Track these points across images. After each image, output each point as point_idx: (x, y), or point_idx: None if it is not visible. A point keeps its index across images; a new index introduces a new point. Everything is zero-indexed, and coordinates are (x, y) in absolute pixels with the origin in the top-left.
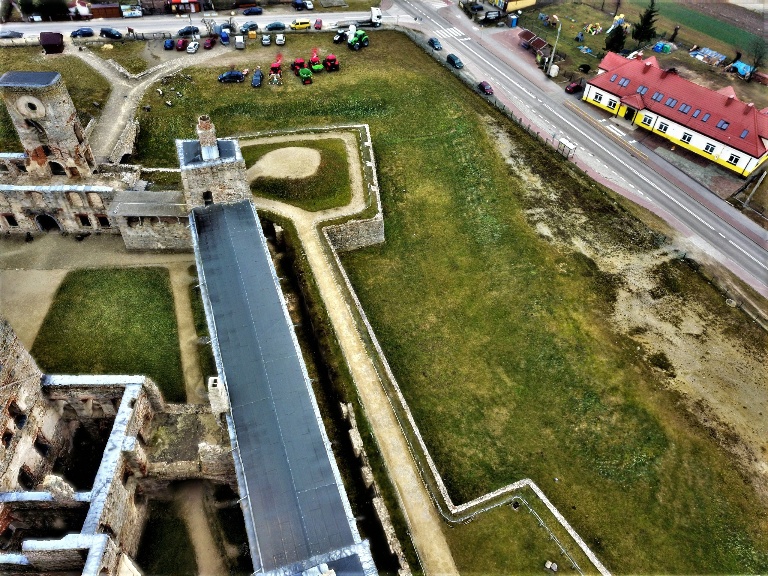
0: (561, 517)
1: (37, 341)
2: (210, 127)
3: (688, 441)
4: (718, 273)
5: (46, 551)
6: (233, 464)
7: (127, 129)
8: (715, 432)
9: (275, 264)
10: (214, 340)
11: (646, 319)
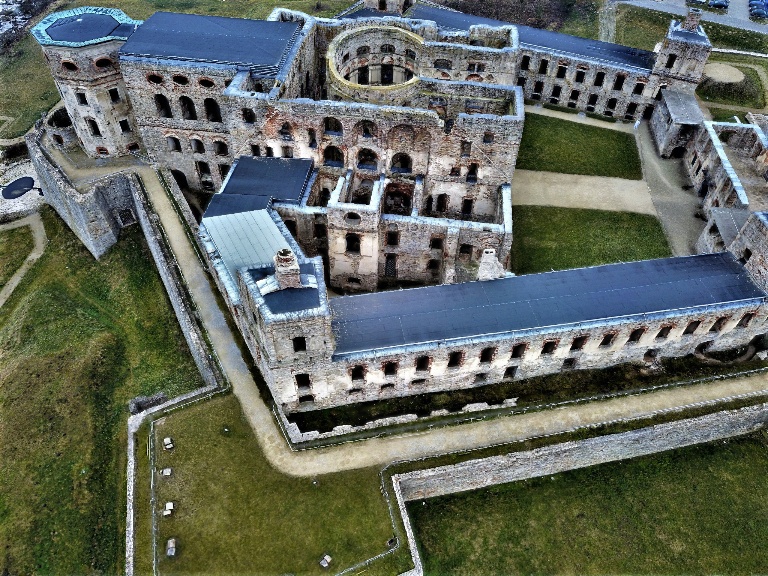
0: None
1: (576, 209)
2: None
3: None
4: None
5: None
6: None
7: None
8: None
9: (712, 361)
10: None
11: None
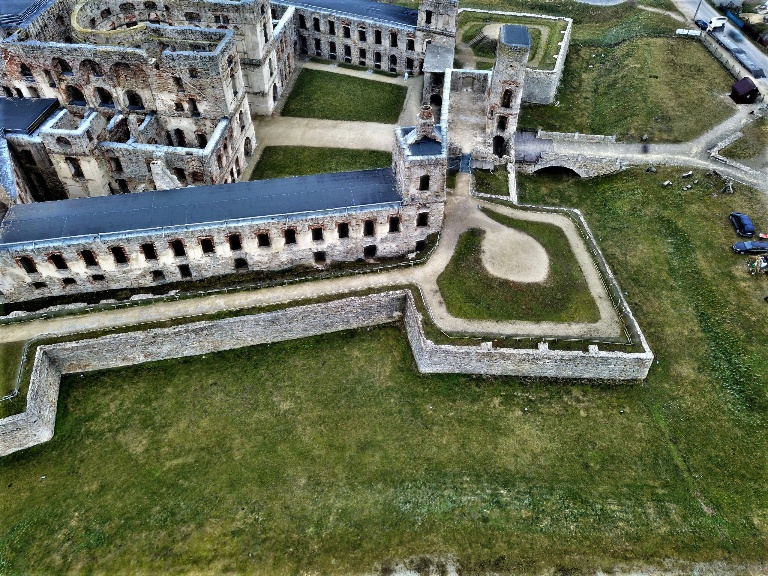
0: None
1: (323, 148)
2: (422, 117)
3: None
4: None
5: None
6: None
7: (603, 160)
8: None
9: None
10: None
11: None
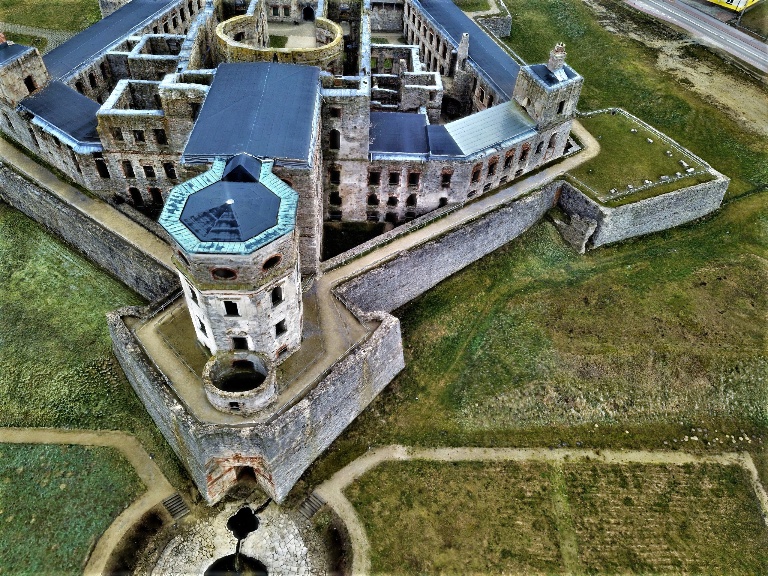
0: (637, 118)
1: None
2: None
3: (702, 109)
4: (719, 51)
5: (415, 76)
6: (469, 86)
7: None
8: (717, 106)
9: None
10: (448, 38)
11: (676, 66)
